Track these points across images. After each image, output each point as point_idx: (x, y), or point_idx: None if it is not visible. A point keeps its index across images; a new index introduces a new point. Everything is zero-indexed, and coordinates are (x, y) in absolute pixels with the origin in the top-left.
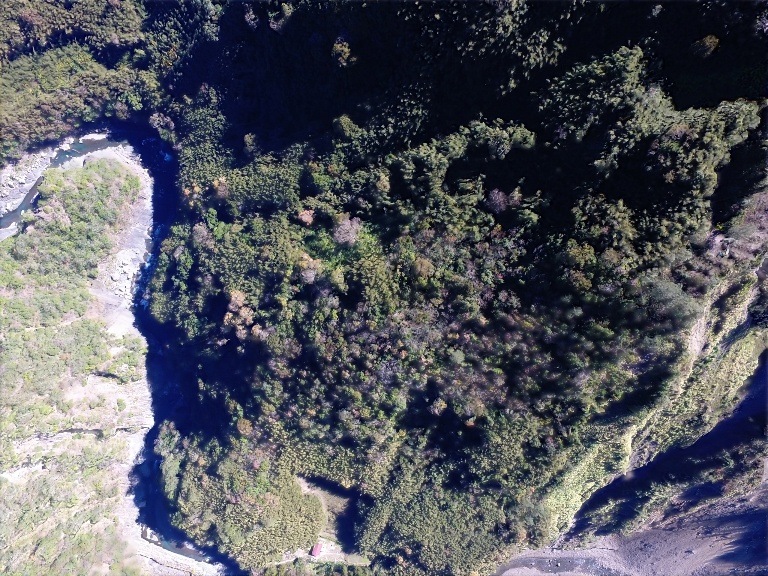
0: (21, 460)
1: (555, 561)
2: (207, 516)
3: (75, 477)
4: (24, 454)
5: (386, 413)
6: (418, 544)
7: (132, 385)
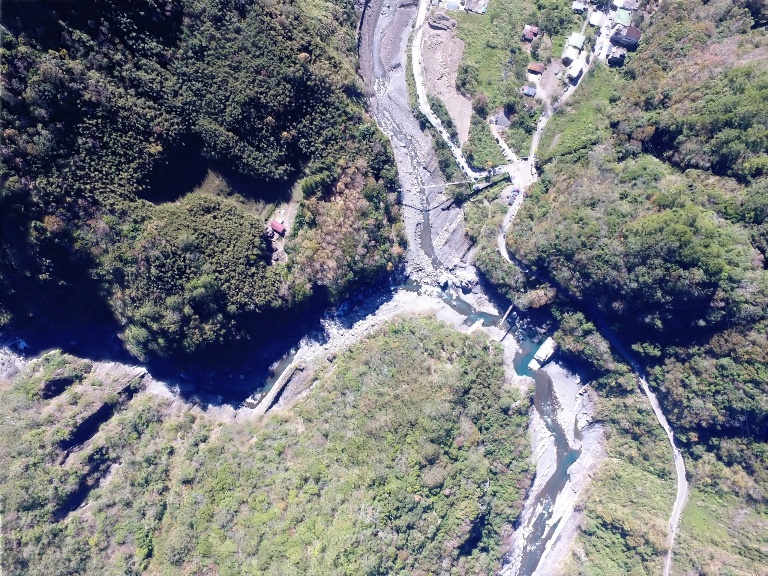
0: (81, 470)
1: (384, 8)
2: (169, 301)
3: (145, 440)
4: (75, 465)
5: (8, 48)
6: (260, 106)
7: (93, 375)
